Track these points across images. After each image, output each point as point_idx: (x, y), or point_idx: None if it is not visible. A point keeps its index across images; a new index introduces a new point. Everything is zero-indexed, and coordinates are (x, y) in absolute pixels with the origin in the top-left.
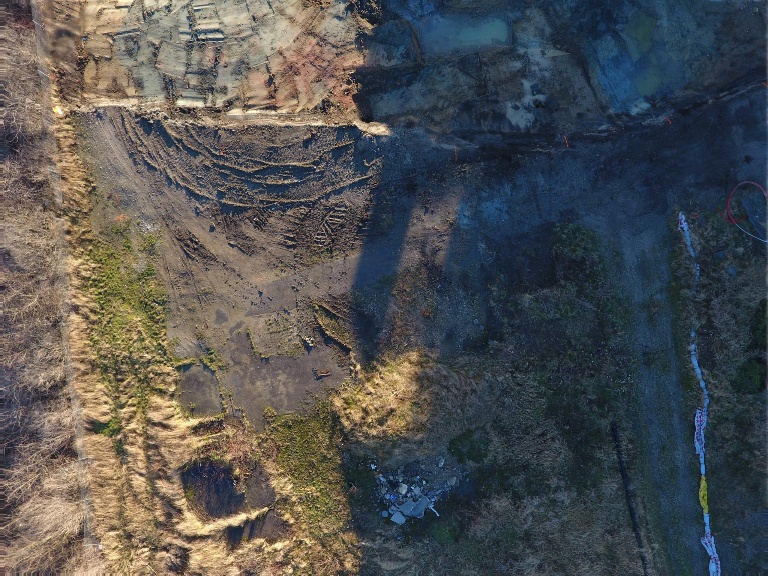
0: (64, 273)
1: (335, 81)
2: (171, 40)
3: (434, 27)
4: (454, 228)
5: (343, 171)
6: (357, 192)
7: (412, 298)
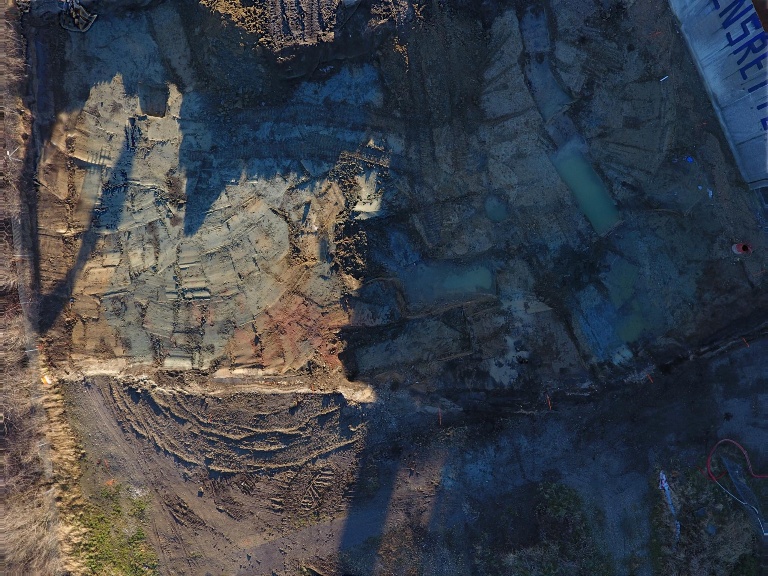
0: (55, 544)
1: (321, 340)
2: (158, 300)
3: (419, 276)
4: (439, 490)
5: (329, 436)
6: (343, 455)
7: (398, 558)
